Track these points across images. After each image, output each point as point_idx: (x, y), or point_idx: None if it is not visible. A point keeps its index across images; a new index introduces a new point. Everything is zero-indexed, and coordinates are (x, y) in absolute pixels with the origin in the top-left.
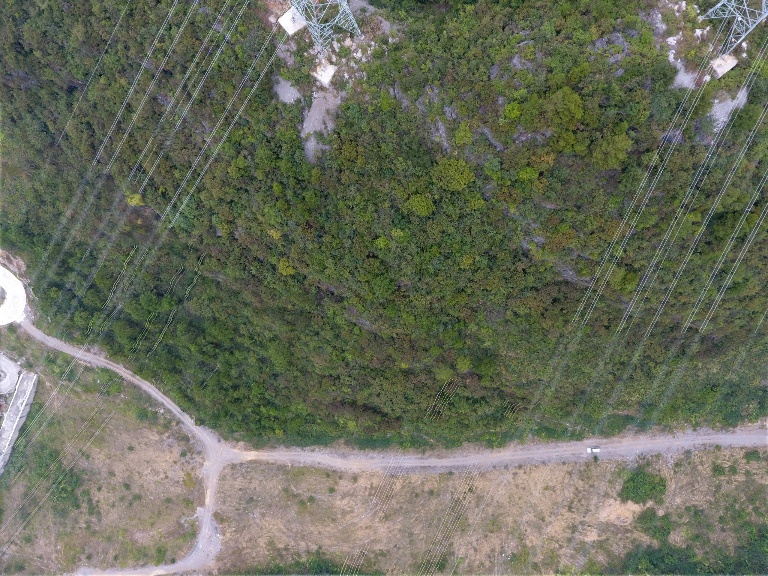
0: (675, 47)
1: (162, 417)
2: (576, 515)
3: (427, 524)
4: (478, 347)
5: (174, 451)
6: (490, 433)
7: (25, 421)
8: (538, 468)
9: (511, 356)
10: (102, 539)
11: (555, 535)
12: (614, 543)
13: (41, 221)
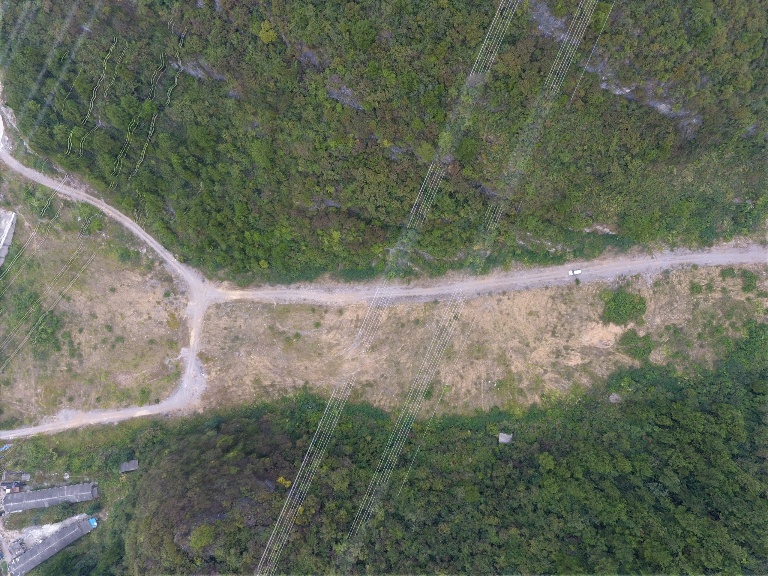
0: None
1: (145, 258)
2: (560, 340)
3: (413, 353)
4: (459, 128)
5: (157, 292)
6: (474, 256)
7: (3, 263)
8: (521, 293)
9: (491, 142)
10: (84, 381)
11: (540, 360)
12: (597, 365)
13: (18, 23)
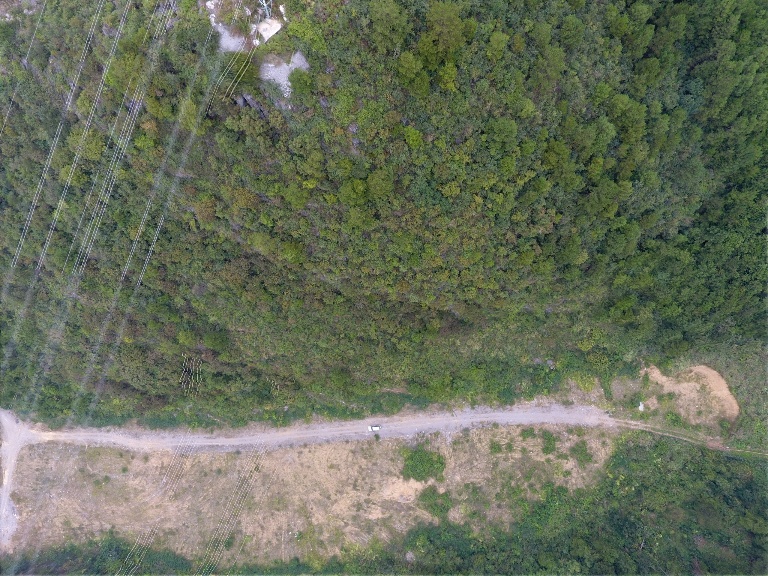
0: (214, 11)
1: None
2: (361, 493)
3: (215, 503)
4: (205, 322)
5: None
6: (270, 412)
7: None
8: (322, 447)
9: (245, 331)
10: None
11: (340, 513)
12: (397, 520)
13: None
